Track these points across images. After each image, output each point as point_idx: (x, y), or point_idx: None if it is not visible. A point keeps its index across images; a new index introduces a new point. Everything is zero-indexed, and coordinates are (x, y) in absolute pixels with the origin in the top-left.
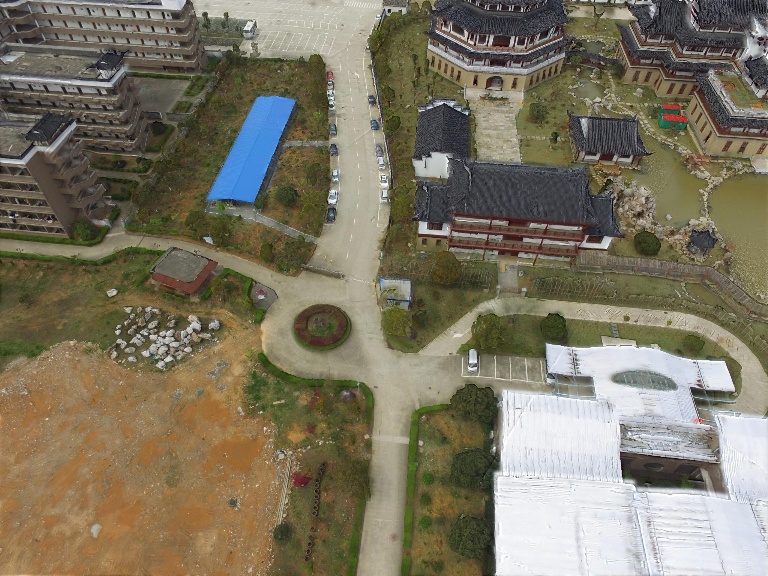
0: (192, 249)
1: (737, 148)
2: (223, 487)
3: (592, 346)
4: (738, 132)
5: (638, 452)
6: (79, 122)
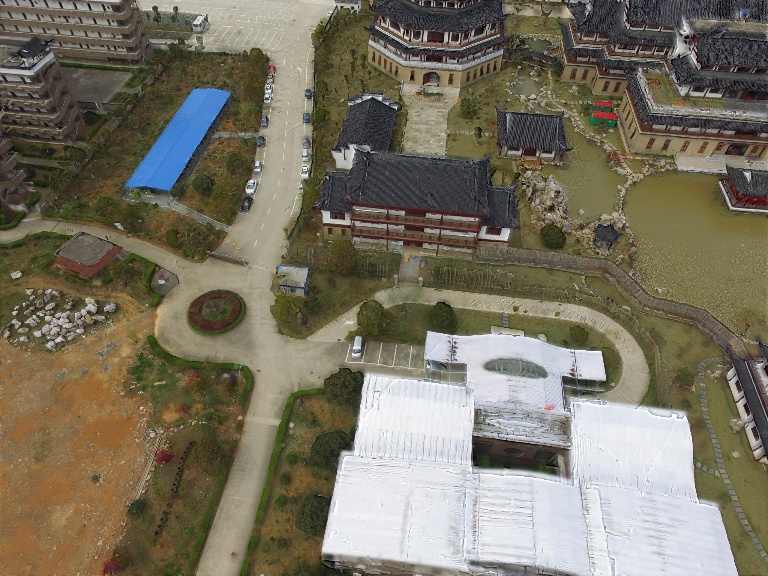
0: (104, 235)
1: (660, 145)
2: (89, 463)
3: None
4: (660, 129)
5: (493, 437)
6: (7, 110)
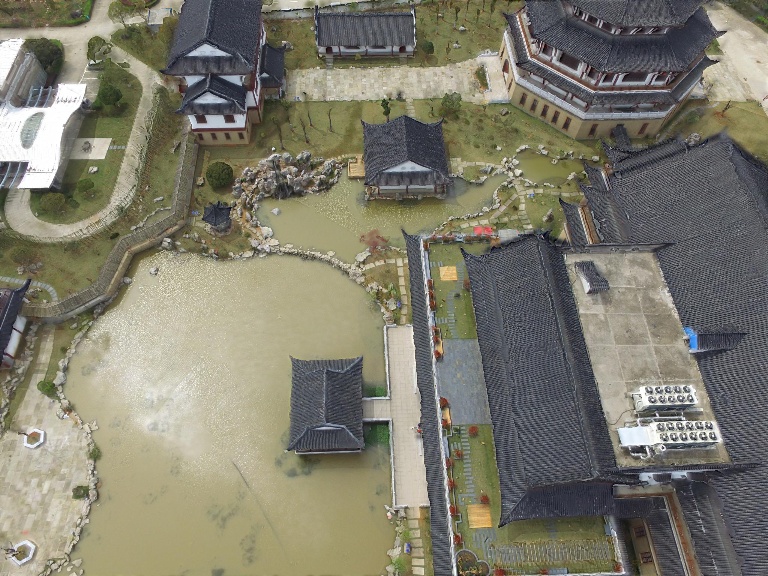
0: None
1: None
2: None
3: (102, 131)
4: None
5: None
6: None
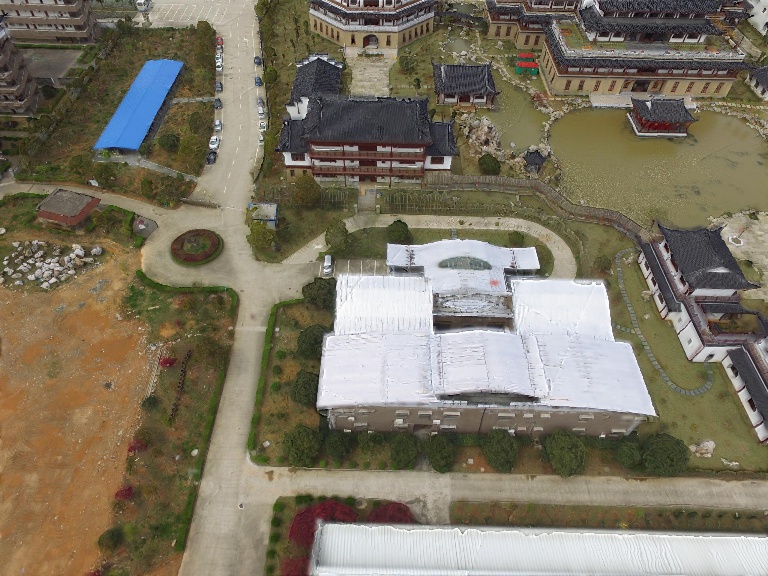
0: (79, 192)
1: (576, 86)
2: (99, 375)
3: None
4: (574, 71)
5: (450, 315)
6: None
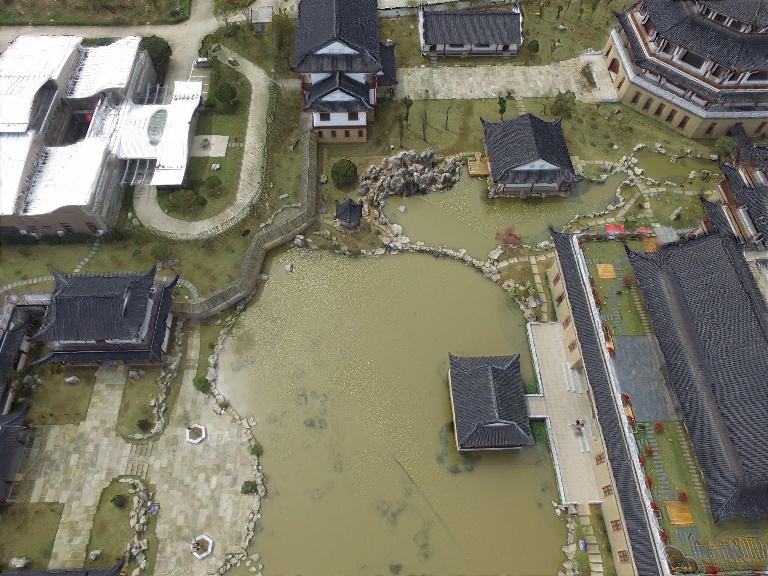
0: None
1: (559, 293)
2: None
3: (218, 128)
4: None
5: None
6: None
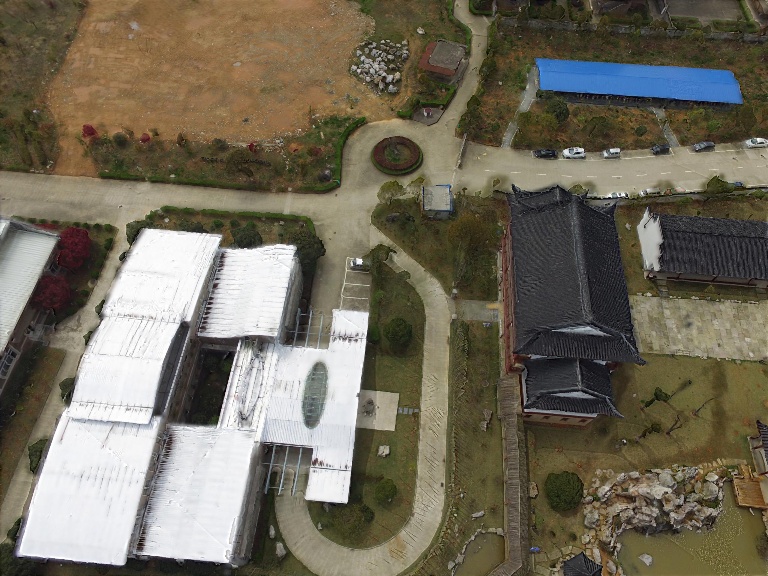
0: (478, 66)
1: None
2: (258, 114)
3: (384, 379)
4: None
5: None
6: None
